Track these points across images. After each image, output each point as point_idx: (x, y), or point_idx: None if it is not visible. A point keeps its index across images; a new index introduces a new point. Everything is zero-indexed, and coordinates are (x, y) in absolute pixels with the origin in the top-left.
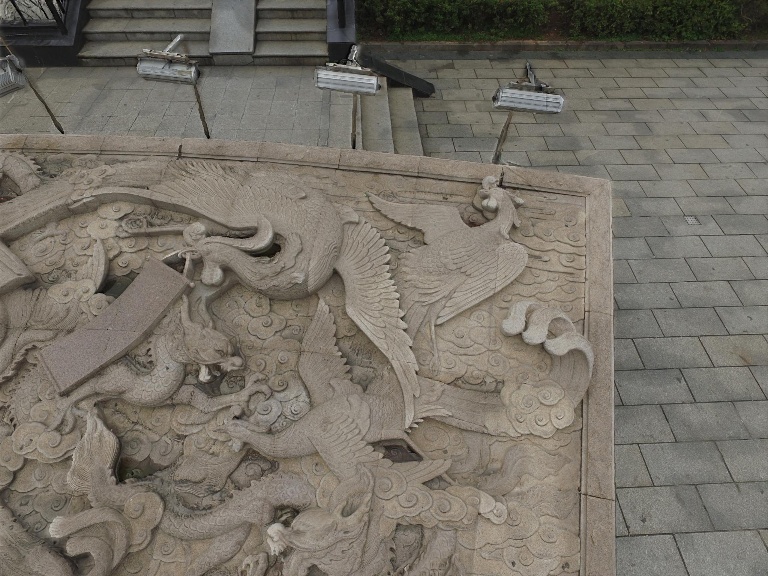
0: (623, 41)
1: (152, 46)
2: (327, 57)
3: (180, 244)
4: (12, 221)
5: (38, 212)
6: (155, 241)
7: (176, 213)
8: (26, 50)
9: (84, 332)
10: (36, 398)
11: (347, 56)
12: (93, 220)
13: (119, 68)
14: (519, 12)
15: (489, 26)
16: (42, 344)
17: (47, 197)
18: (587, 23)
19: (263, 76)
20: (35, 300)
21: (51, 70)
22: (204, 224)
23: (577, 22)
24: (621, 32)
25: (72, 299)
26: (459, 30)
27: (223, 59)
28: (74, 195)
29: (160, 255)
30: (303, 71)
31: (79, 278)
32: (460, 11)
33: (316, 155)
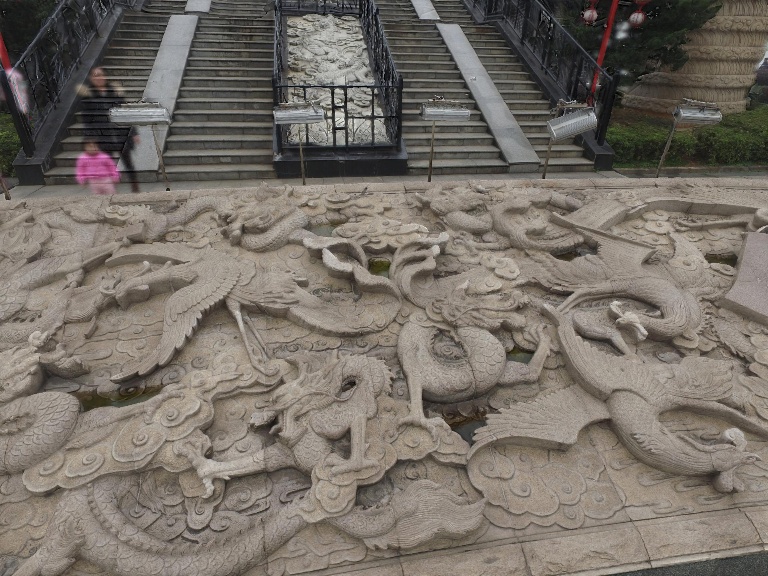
0: (746, 166)
1: (458, 161)
2: (593, 165)
3: (728, 234)
4: (594, 222)
5: (612, 215)
6: (706, 233)
7: (705, 216)
8: (370, 163)
9: (743, 283)
10: (743, 335)
11: (607, 164)
12: (643, 223)
13: (438, 175)
14: (676, 147)
15: (649, 159)
16: (710, 296)
17: (603, 208)
18: (722, 154)
19: (555, 177)
20: (666, 270)
21: (386, 177)
22: (748, 216)
23: (715, 153)
24: (743, 160)
25: (696, 267)
26: (629, 161)
27: (517, 168)
28: (629, 204)
29: (718, 242)
30: (579, 174)
31: (683, 255)
32: (636, 146)
33: (761, 182)
